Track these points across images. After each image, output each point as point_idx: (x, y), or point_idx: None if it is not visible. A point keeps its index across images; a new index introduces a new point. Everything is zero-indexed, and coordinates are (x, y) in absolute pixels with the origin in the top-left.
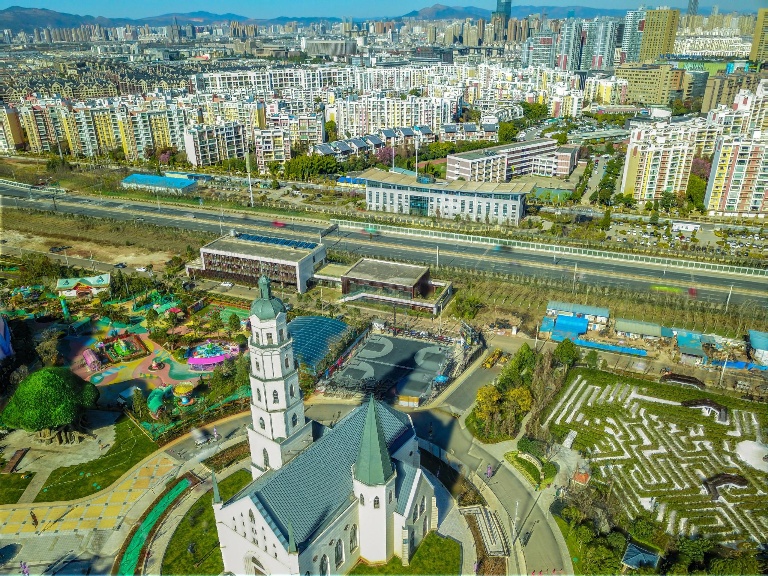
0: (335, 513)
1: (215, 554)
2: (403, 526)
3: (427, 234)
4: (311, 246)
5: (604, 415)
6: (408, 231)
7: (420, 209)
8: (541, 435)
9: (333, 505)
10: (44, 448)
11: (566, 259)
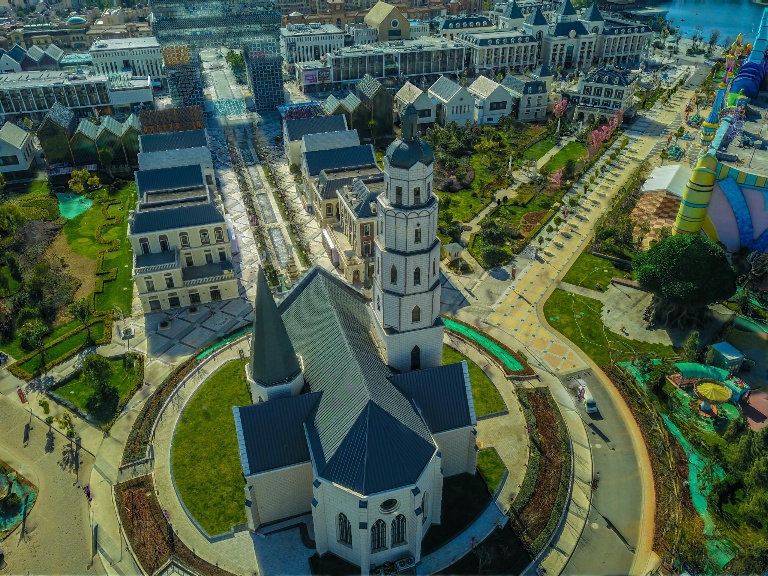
0: None
1: None
2: None
3: None
4: None
5: None
6: None
7: None
8: None
9: None
10: (645, 299)
11: None
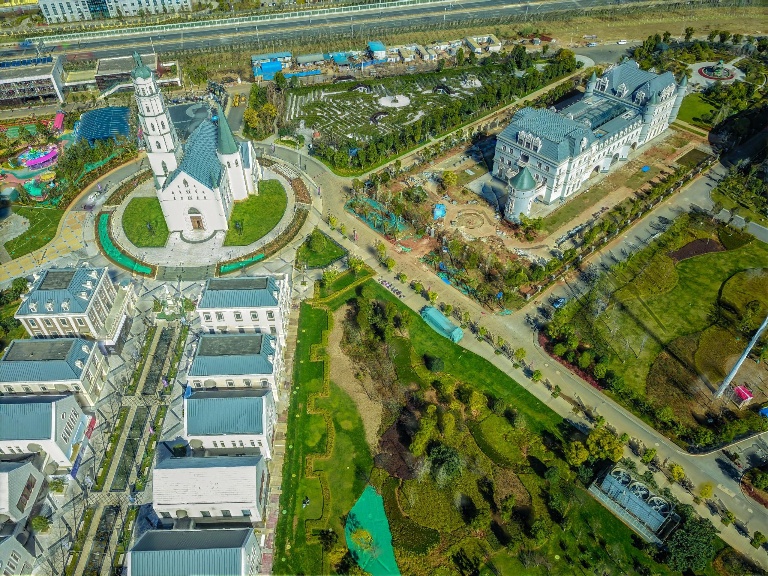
0: (220, 173)
1: (158, 229)
2: (251, 174)
3: (125, 32)
4: (48, 60)
5: (313, 108)
6: (106, 33)
7: (101, 12)
8: (288, 126)
9: (217, 171)
10: None
11: (242, 27)
